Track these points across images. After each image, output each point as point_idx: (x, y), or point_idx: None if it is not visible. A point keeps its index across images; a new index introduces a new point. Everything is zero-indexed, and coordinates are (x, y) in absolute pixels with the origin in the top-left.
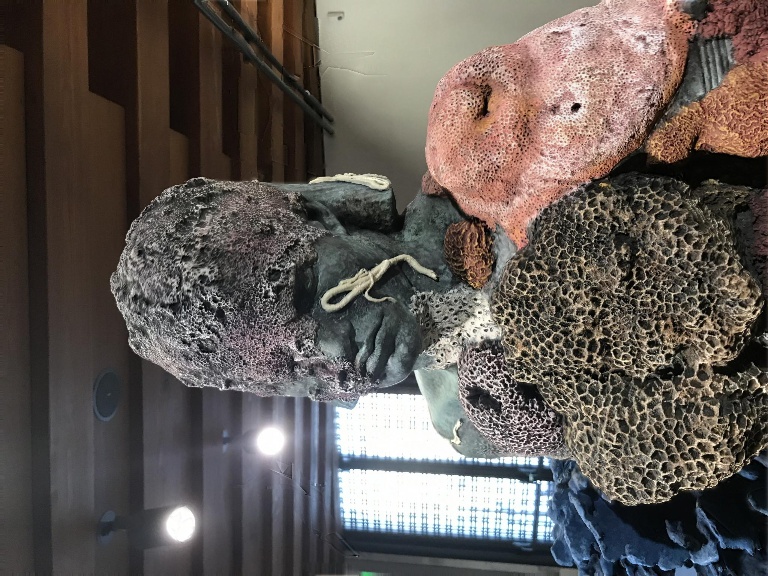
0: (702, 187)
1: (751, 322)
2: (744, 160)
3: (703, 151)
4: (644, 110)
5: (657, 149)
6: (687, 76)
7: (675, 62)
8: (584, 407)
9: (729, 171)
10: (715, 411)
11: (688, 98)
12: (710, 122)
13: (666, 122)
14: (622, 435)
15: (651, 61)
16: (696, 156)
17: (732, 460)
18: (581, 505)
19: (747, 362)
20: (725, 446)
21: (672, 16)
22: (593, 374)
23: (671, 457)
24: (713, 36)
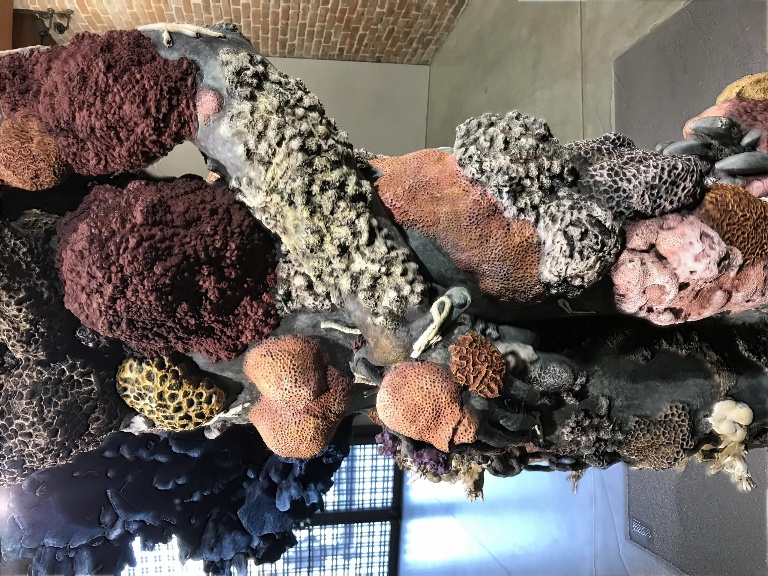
0: (25, 215)
1: (32, 320)
2: None
3: (7, 185)
4: None
5: None
6: None
7: None
8: None
9: (49, 203)
10: (24, 395)
11: None
12: None
13: None
14: None
15: None
16: (4, 189)
17: (43, 435)
18: (12, 501)
19: (63, 355)
20: (36, 424)
21: None
22: None
23: (0, 439)
24: None
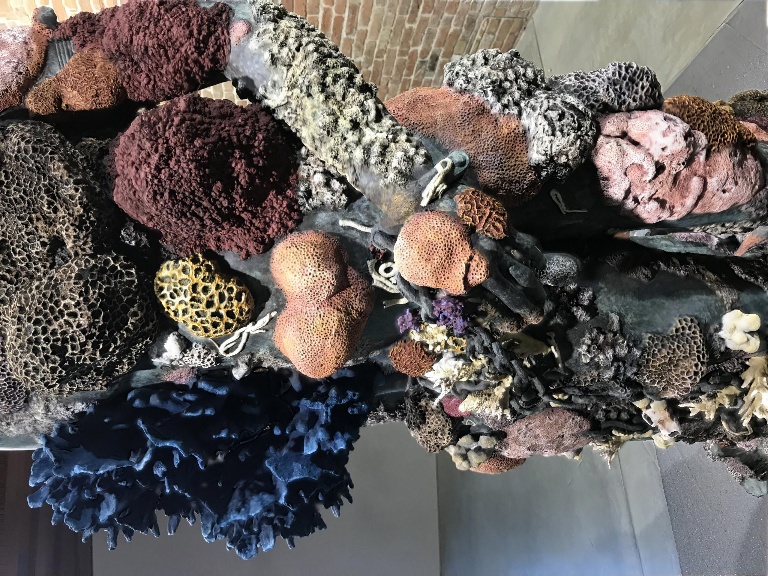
0: (82, 141)
1: (86, 205)
2: (103, 121)
3: (70, 111)
4: (13, 74)
5: (31, 104)
6: (49, 61)
7: (35, 49)
8: (6, 311)
9: (103, 133)
10: (73, 277)
11: (51, 74)
12: (63, 87)
13: (35, 87)
14: (23, 319)
15: (16, 46)
16: (67, 115)
17: (88, 314)
18: (45, 437)
19: (109, 251)
20: (82, 303)
21: (34, 25)
22: (10, 281)
23: (48, 321)
24: (61, 38)
